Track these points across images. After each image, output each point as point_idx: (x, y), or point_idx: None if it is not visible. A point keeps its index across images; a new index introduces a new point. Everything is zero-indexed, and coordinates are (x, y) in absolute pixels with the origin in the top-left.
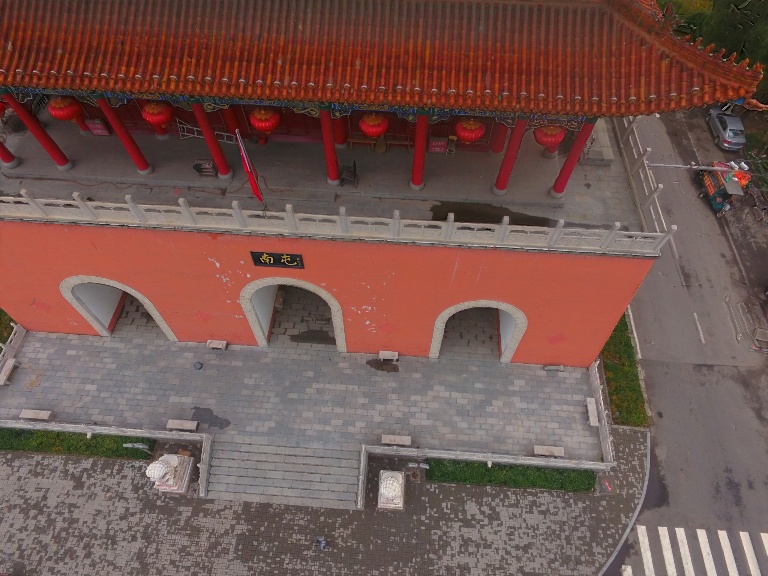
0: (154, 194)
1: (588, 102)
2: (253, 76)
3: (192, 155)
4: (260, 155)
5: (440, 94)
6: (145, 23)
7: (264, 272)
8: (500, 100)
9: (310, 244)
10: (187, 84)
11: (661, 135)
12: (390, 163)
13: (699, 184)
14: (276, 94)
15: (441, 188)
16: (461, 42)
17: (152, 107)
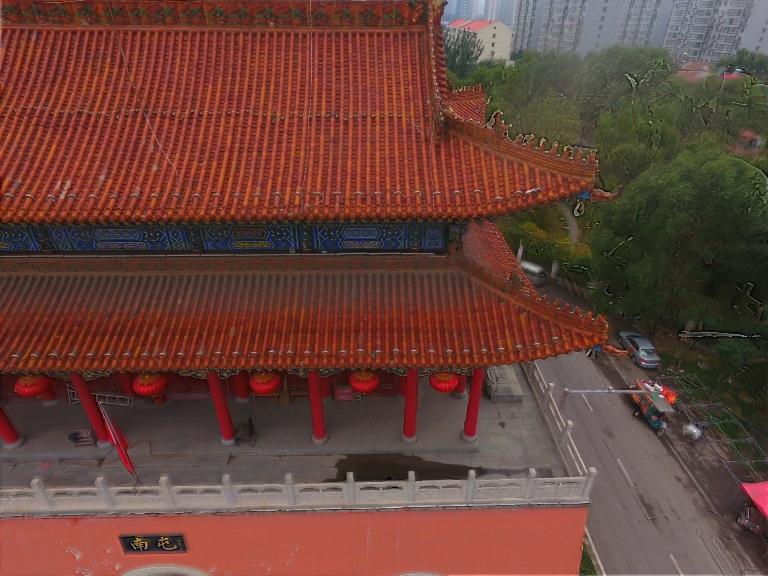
0: (15, 472)
1: (460, 354)
2: (121, 349)
3: (76, 422)
4: (153, 416)
5: (313, 355)
6: (23, 306)
7: (137, 562)
8: (374, 357)
9: (191, 521)
10: (48, 361)
11: (583, 358)
12: (294, 415)
13: (631, 402)
14: (141, 366)
15: (346, 440)
16: (334, 307)
17: (26, 379)
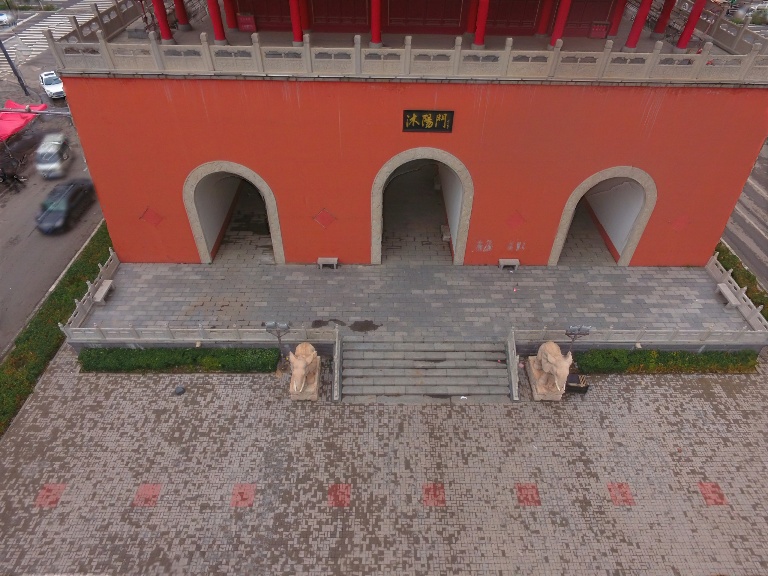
0: None
1: None
2: None
3: None
4: None
5: None
6: None
7: None
8: None
9: None
10: None
11: None
12: None
13: None
14: None
15: None
16: None
17: None
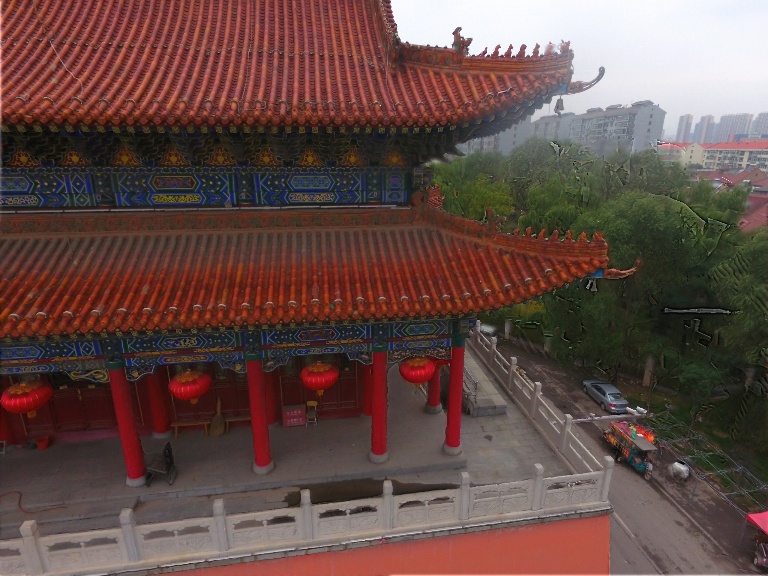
0: None
1: (439, 300)
2: None
3: None
4: (31, 463)
5: (253, 309)
6: None
7: None
8: (332, 309)
9: None
10: None
11: None
12: (229, 446)
13: (610, 448)
14: (6, 328)
15: (299, 466)
16: (281, 263)
17: None
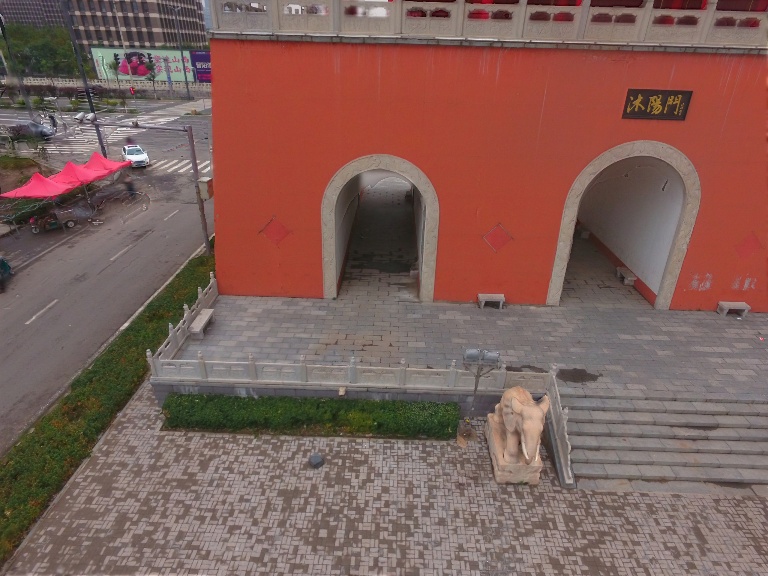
0: None
1: None
2: None
3: None
4: None
5: None
6: None
7: None
8: None
9: None
10: None
11: None
12: None
13: None
14: None
15: None
16: None
17: None
